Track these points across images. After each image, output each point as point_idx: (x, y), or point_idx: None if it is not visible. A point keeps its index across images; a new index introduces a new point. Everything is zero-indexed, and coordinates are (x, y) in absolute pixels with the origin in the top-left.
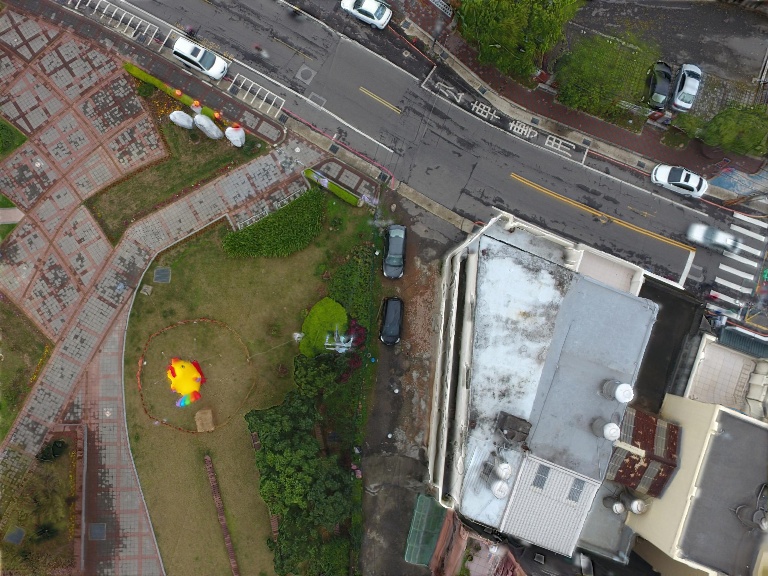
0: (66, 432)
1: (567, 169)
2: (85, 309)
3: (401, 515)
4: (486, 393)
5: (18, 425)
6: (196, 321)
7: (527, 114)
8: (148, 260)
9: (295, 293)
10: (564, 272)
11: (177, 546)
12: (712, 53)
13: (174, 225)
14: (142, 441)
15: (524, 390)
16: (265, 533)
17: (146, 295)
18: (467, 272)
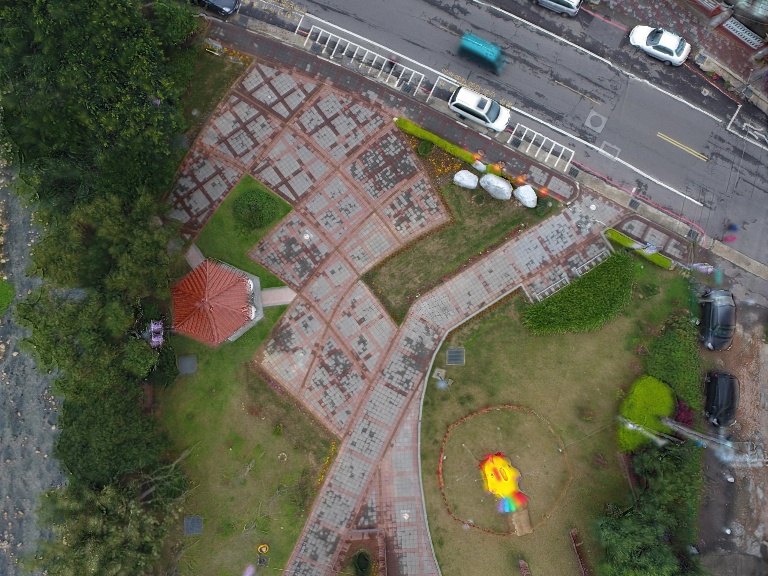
0: (365, 540)
1: None
2: (372, 398)
3: None
4: None
5: (308, 533)
6: (500, 408)
7: None
8: (437, 340)
9: (608, 372)
10: None
11: None
12: None
13: (463, 299)
14: (447, 546)
15: None
16: None
17: (439, 380)
18: None
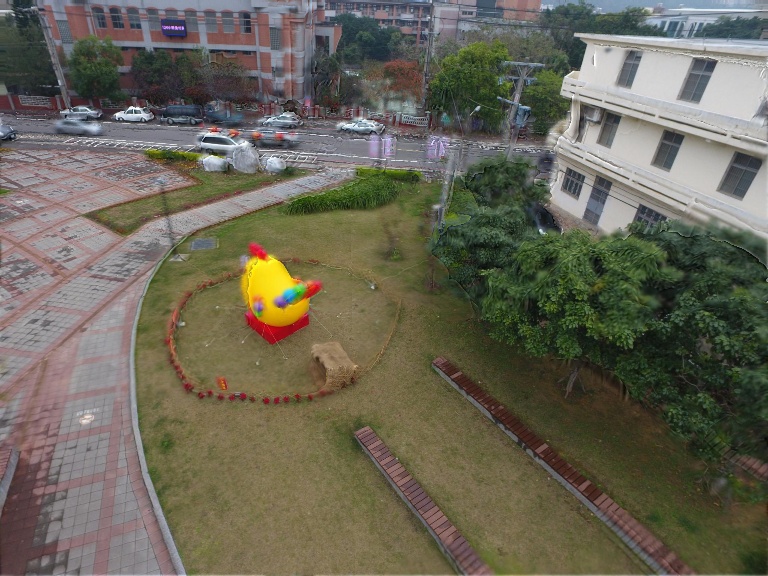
0: None
1: None
2: (62, 290)
3: None
4: None
5: None
6: None
7: (523, 146)
8: (181, 238)
9: (402, 229)
10: None
11: None
12: None
13: (216, 215)
14: (182, 447)
15: None
16: (615, 572)
17: (180, 261)
18: None
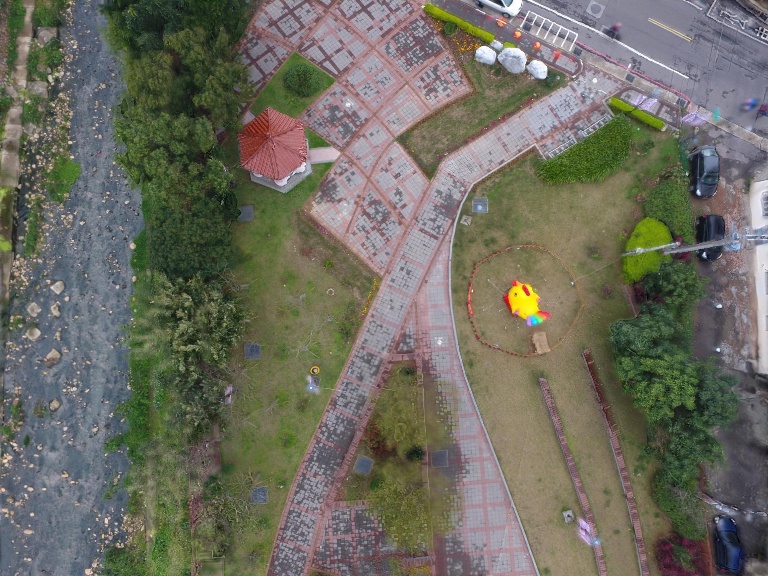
0: (405, 361)
1: None
2: (408, 241)
3: (736, 427)
4: None
5: (354, 357)
6: (520, 247)
7: None
8: (464, 192)
9: (611, 216)
10: None
11: (520, 469)
12: None
13: (485, 157)
14: (476, 367)
15: None
16: (605, 451)
17: (466, 225)
18: None
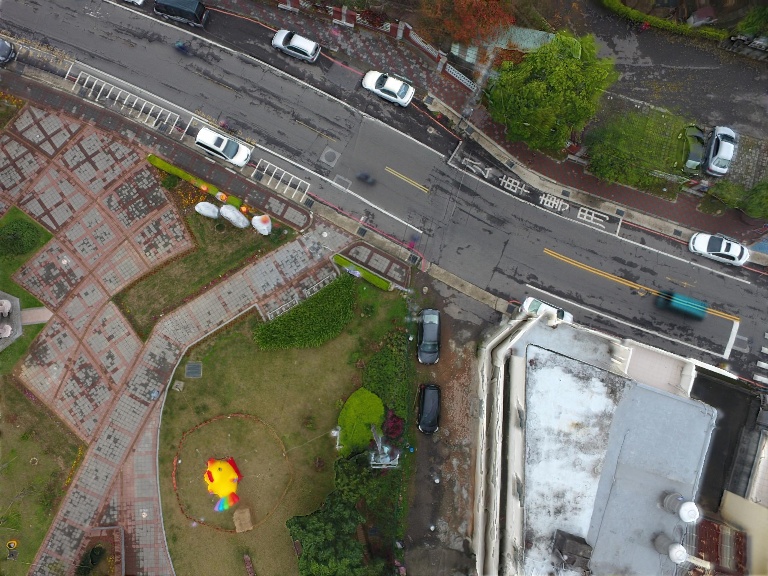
0: (103, 536)
1: (601, 242)
2: (117, 408)
3: None
4: (541, 511)
5: (54, 530)
6: (230, 416)
7: (557, 187)
8: (178, 355)
9: (329, 383)
10: (616, 379)
11: None
12: (744, 113)
13: (203, 317)
14: (180, 542)
15: (581, 506)
16: None
17: (178, 391)
18: (511, 373)
